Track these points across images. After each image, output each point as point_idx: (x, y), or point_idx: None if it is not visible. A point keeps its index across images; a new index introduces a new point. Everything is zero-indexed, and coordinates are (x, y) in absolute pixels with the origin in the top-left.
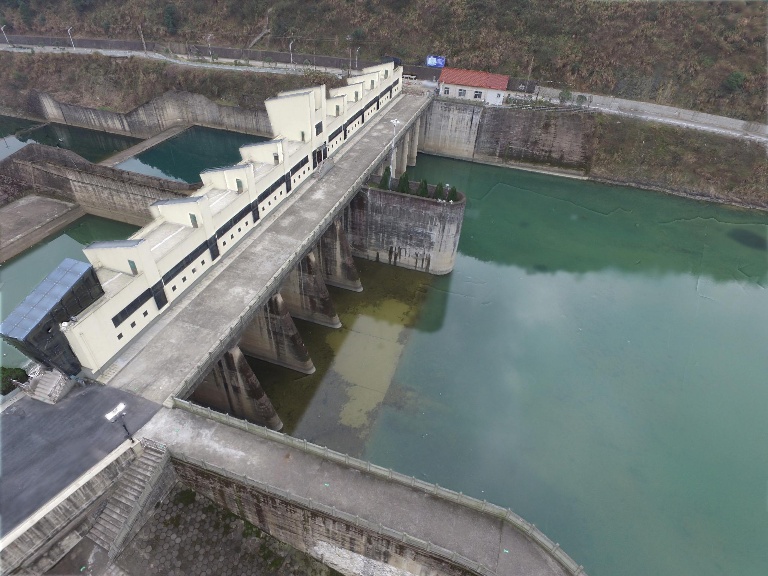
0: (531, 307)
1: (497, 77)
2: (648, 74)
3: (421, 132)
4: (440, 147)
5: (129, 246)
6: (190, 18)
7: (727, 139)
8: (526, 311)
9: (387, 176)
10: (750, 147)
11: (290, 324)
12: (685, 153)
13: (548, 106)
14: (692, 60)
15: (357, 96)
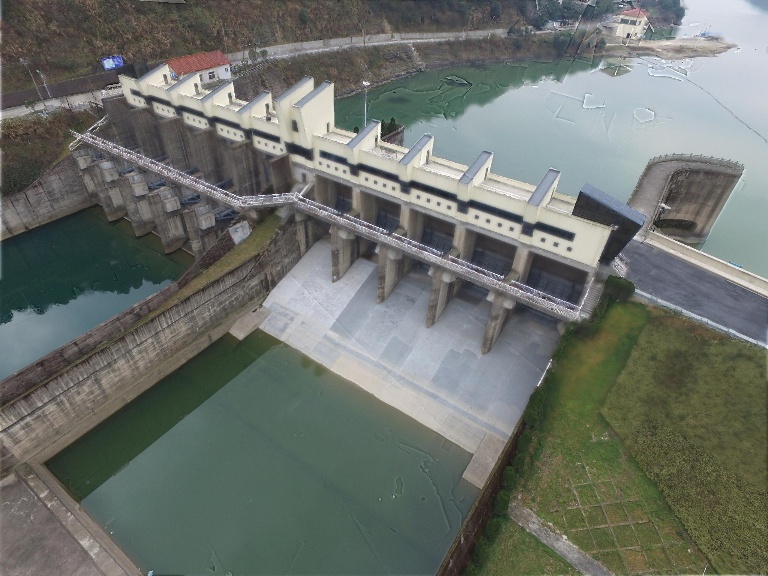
0: None
1: (214, 54)
2: (263, 24)
3: None
4: None
5: (553, 177)
6: None
7: (335, 53)
8: None
9: None
10: (346, 53)
11: None
12: (330, 69)
13: (255, 66)
14: (276, 7)
15: (231, 97)
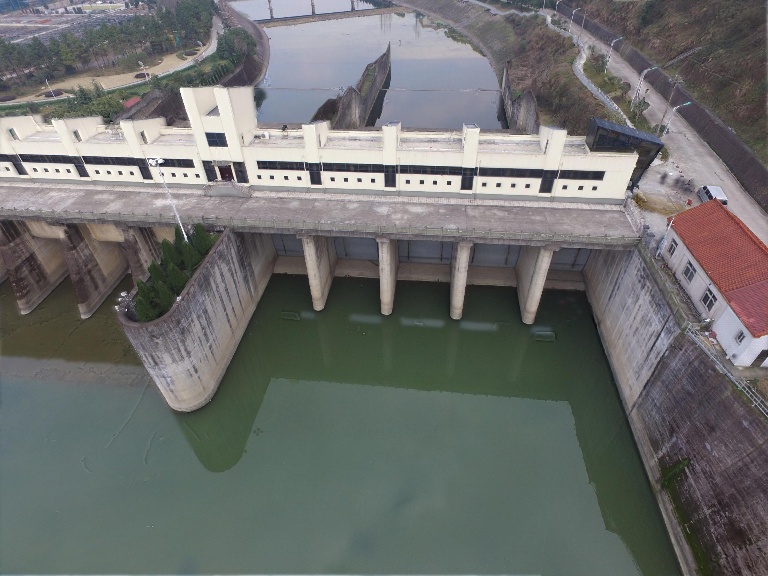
0: (68, 545)
1: None
2: None
3: (608, 291)
4: (613, 341)
5: None
6: (664, 15)
7: None
8: (60, 535)
9: (176, 230)
10: None
11: (3, 257)
12: None
13: None
14: None
15: None
